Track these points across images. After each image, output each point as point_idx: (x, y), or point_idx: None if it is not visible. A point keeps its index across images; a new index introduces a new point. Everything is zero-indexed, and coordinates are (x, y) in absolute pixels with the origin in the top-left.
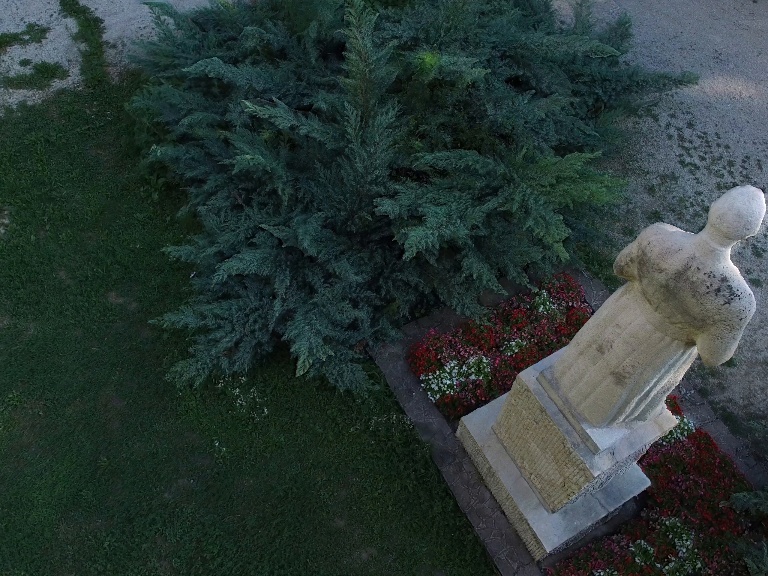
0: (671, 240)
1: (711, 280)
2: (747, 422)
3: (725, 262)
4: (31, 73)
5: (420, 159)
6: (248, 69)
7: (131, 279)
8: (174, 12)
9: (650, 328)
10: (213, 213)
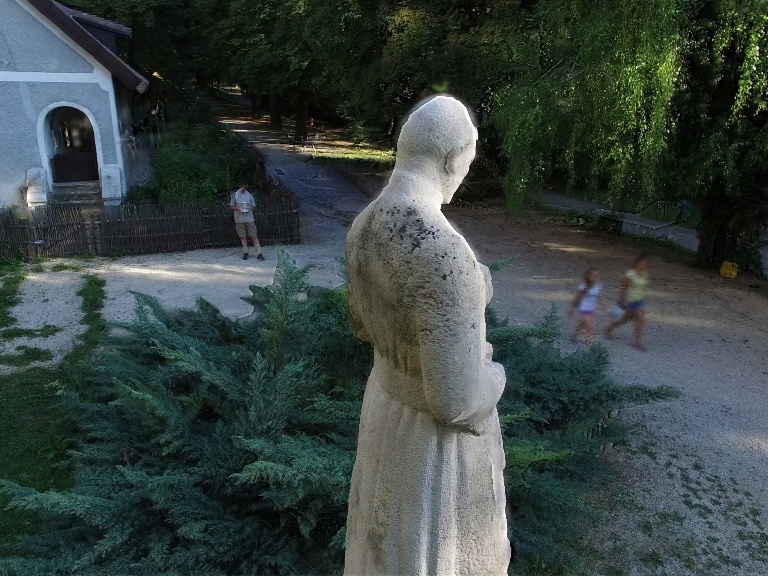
0: None
1: (394, 218)
2: None
3: (418, 197)
4: (19, 354)
5: (313, 403)
6: (192, 340)
7: None
8: (157, 305)
9: (383, 397)
10: (90, 468)
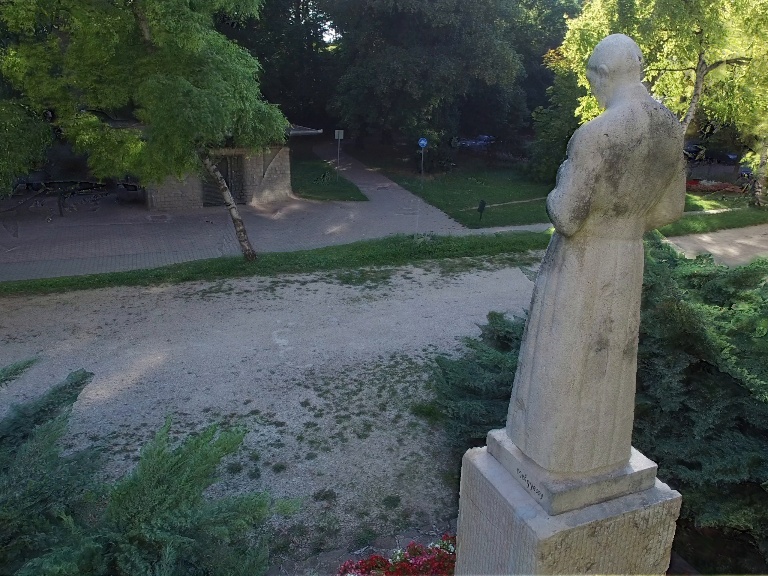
0: (617, 114)
1: (666, 111)
2: None
3: None
4: None
5: None
6: None
7: None
8: None
9: (632, 245)
10: None
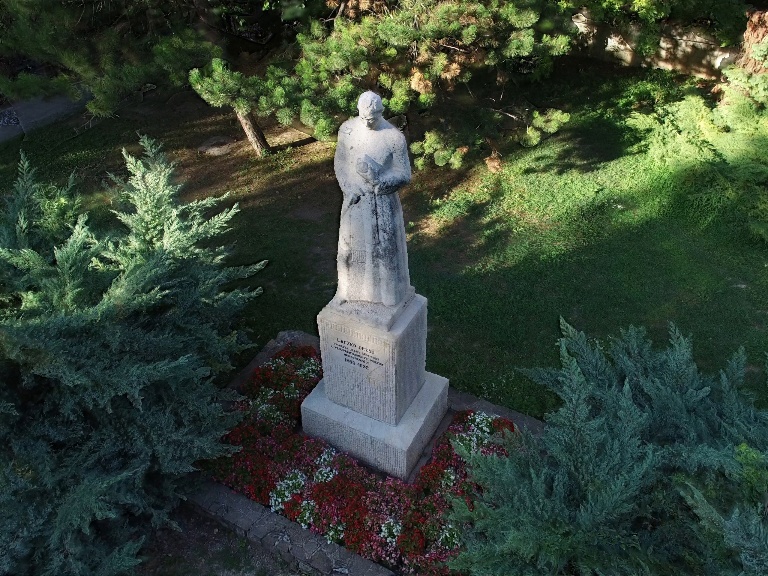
0: None
1: None
2: (215, 568)
3: None
4: None
5: None
6: None
7: (762, 382)
8: None
9: None
10: None
